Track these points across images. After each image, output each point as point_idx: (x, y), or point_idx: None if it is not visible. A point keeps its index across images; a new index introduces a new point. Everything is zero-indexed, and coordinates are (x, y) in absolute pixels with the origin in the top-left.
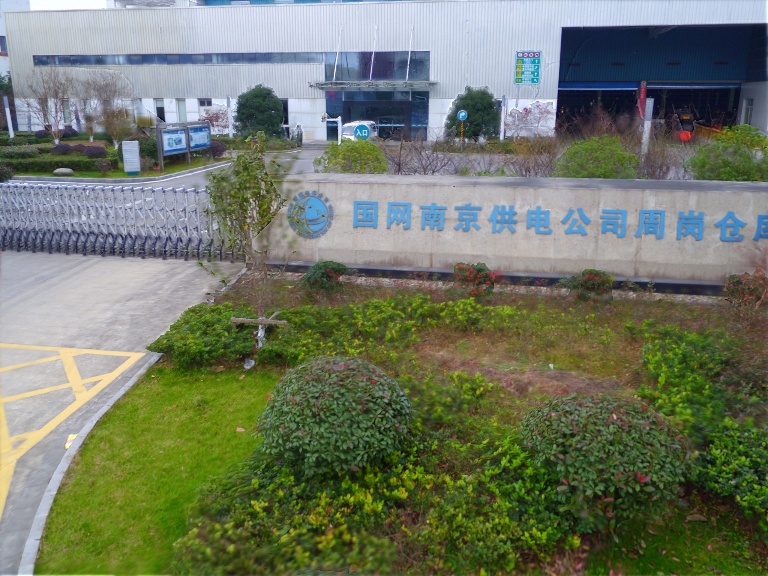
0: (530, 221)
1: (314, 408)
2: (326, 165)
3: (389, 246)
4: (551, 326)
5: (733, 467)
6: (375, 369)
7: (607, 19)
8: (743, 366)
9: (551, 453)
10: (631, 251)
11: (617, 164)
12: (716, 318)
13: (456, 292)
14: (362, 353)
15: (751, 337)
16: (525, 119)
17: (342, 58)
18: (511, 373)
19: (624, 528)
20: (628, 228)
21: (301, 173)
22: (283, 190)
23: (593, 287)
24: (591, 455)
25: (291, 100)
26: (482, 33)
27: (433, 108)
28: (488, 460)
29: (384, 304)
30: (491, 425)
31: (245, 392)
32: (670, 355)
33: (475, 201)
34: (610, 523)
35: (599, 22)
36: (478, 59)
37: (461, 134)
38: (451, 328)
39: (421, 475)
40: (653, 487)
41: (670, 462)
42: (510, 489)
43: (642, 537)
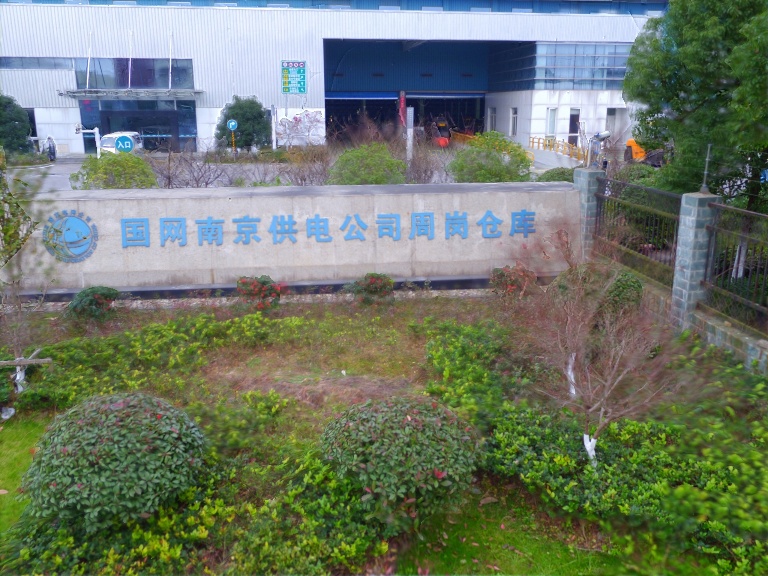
0: (310, 230)
1: (91, 456)
2: (85, 181)
3: (165, 265)
4: (340, 333)
5: (515, 448)
6: (159, 402)
7: (364, 32)
8: (513, 351)
9: (352, 464)
10: (407, 253)
11: (387, 170)
12: (486, 309)
13: (242, 307)
14: (144, 384)
15: (517, 324)
16: (296, 128)
17: (95, 64)
18: (305, 385)
19: (427, 523)
20: (402, 231)
21: (55, 191)
22: (35, 211)
23: (376, 290)
24: (391, 460)
25: (38, 110)
26: (245, 42)
27: (201, 118)
28: (290, 480)
29: (165, 328)
30: (290, 442)
31: (5, 447)
32: (451, 349)
33: (253, 212)
34: (414, 522)
35: (357, 35)
36: (243, 68)
37: (233, 144)
38: (240, 345)
39: (221, 508)
40: (450, 481)
41: (462, 454)
42: (315, 506)
43: (444, 529)
